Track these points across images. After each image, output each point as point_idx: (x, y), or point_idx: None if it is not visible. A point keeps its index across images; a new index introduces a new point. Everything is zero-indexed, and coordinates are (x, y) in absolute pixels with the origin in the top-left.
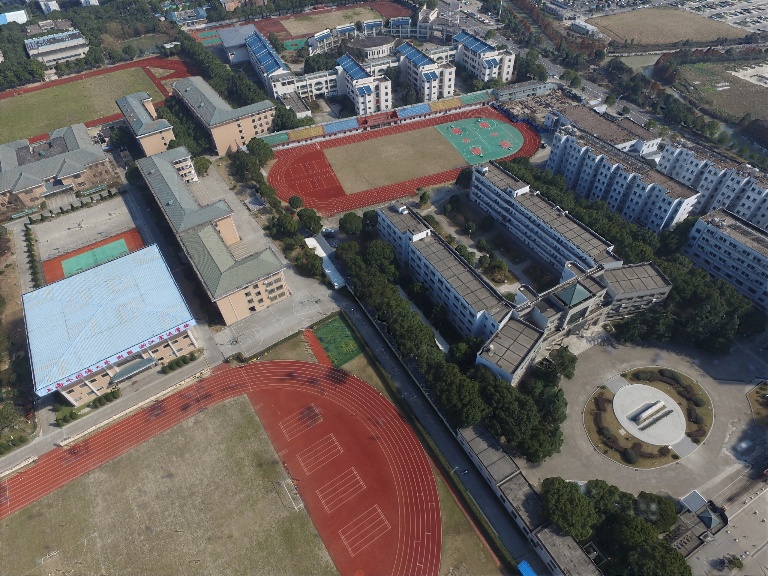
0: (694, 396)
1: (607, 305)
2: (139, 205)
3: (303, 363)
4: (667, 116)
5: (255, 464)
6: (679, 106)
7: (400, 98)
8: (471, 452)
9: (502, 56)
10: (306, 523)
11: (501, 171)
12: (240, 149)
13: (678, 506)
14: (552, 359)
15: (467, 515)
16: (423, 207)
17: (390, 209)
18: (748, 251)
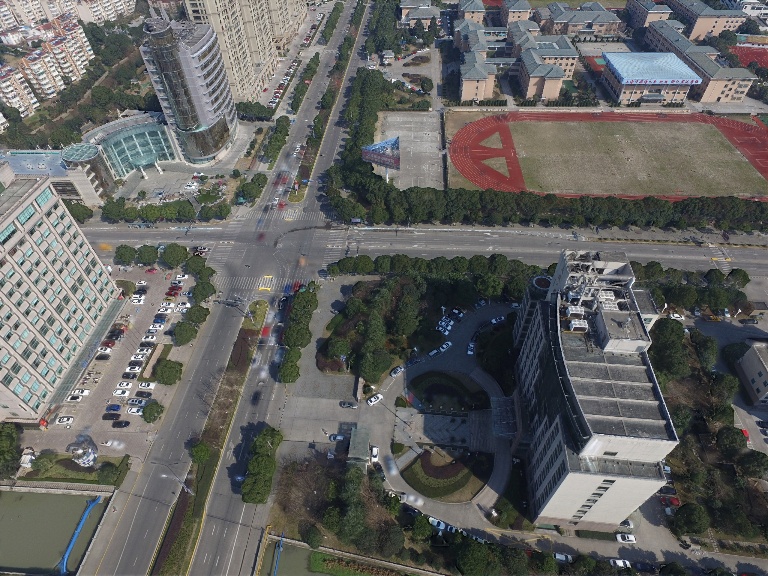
0: None
1: None
2: (636, 49)
3: (750, 125)
4: None
5: (720, 143)
6: None
7: None
8: None
9: None
10: (749, 165)
11: None
12: (711, 36)
13: None
14: None
15: None
16: None
17: None
18: None
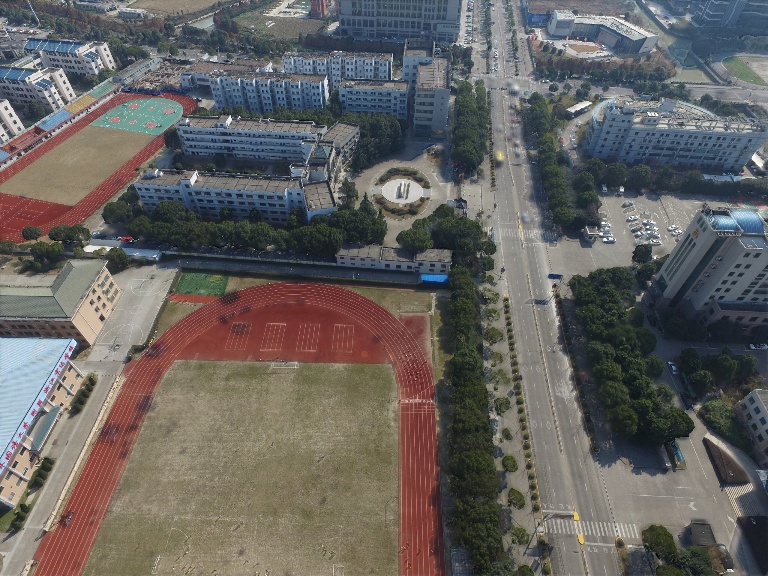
0: (411, 171)
1: (339, 154)
2: None
3: (194, 312)
4: (257, 52)
5: (239, 378)
6: (260, 41)
7: (22, 118)
8: (353, 261)
9: (95, 48)
10: (310, 366)
11: (198, 118)
12: None
13: None
14: (343, 192)
15: (380, 288)
16: None
17: (145, 179)
18: (374, 92)
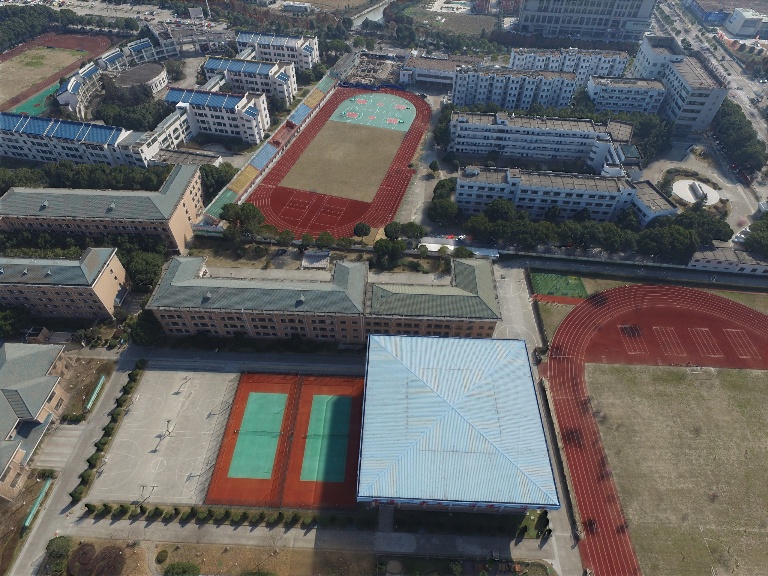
0: (692, 172)
1: None
2: (192, 357)
3: (571, 314)
4: (449, 47)
5: (665, 383)
6: (453, 37)
7: None
8: (707, 263)
9: (309, 41)
10: (728, 372)
11: (470, 115)
12: (213, 228)
13: (758, 216)
14: None
15: (743, 292)
16: (436, 175)
17: (466, 176)
18: (631, 90)
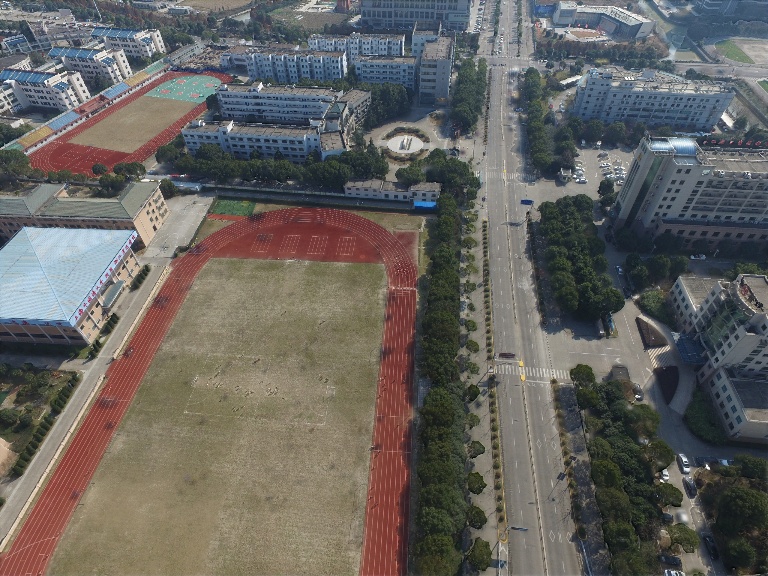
0: (414, 129)
1: (352, 114)
2: None
3: (227, 227)
4: (287, 39)
5: (261, 270)
6: (290, 30)
7: (89, 90)
8: (358, 191)
9: (150, 34)
10: (318, 264)
11: (235, 85)
12: None
13: None
14: (353, 141)
15: (379, 212)
16: None
17: (190, 128)
18: (385, 65)
